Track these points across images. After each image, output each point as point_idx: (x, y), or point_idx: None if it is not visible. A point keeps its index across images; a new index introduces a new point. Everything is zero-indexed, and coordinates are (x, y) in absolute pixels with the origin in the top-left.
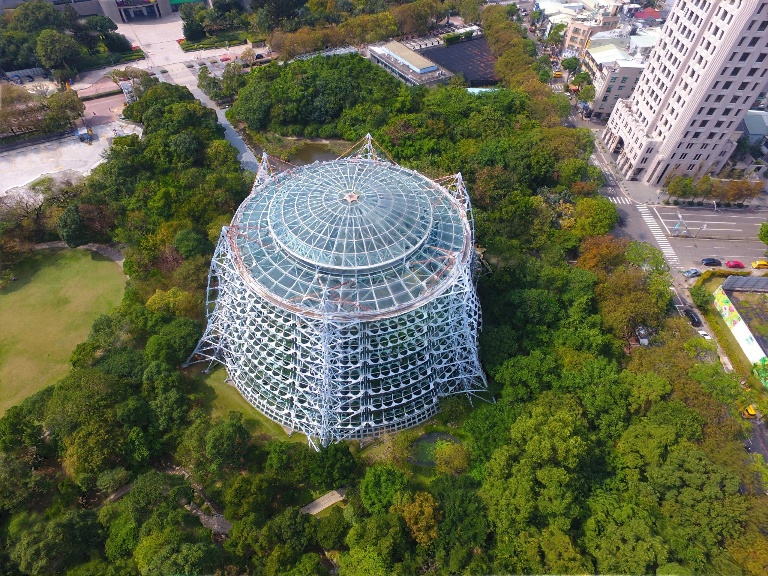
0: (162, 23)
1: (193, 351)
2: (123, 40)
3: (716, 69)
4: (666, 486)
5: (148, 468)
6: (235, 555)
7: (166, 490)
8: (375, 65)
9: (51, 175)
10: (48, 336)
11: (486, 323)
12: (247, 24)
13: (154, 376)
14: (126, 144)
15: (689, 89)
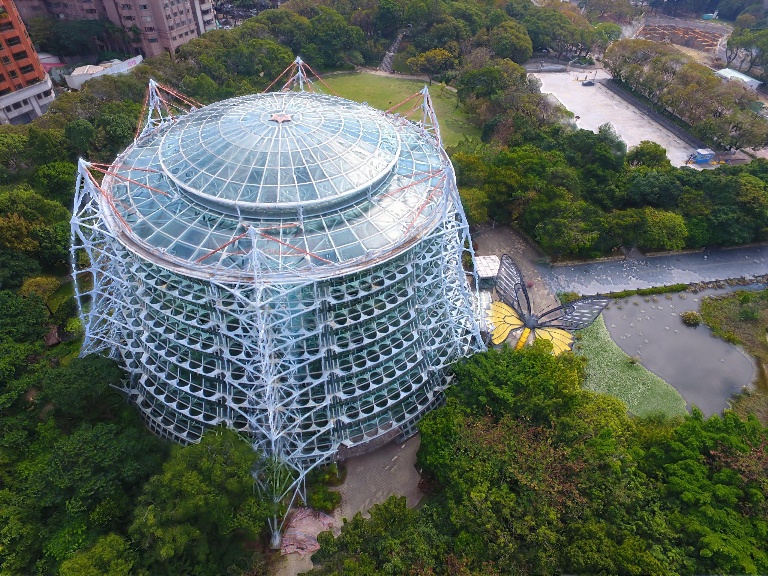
0: None
1: None
2: None
3: None
4: None
5: None
6: None
7: None
8: None
9: (551, 97)
10: None
11: None
12: None
13: None
14: (644, 149)
15: None
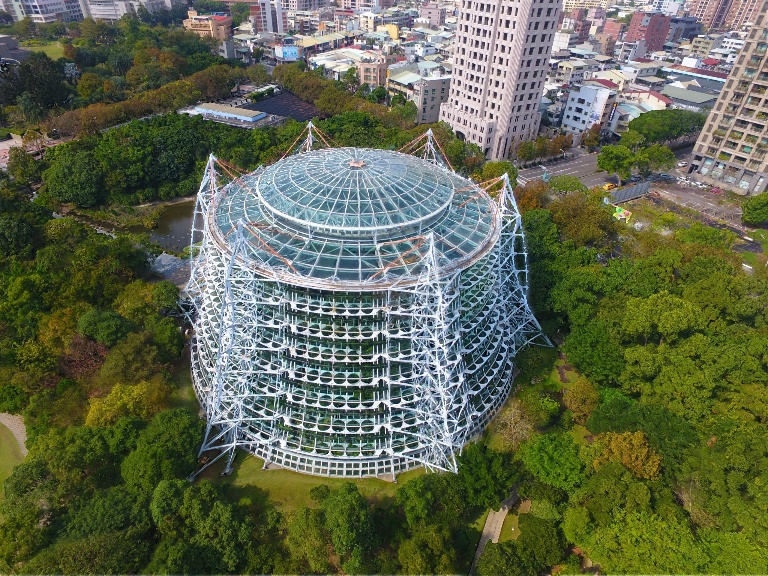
0: None
1: (199, 450)
2: None
3: (519, 51)
4: (753, 315)
5: None
6: None
7: None
8: None
9: None
10: None
11: None
12: (4, 117)
13: (172, 503)
14: None
15: (503, 73)
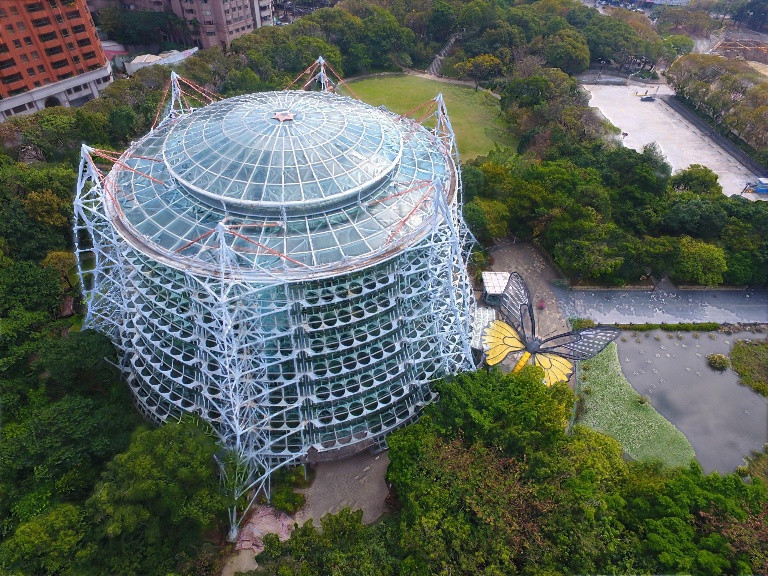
0: None
1: None
2: None
3: None
4: None
5: None
6: None
7: None
8: None
9: (596, 111)
10: None
11: None
12: None
13: None
14: (692, 173)
15: None
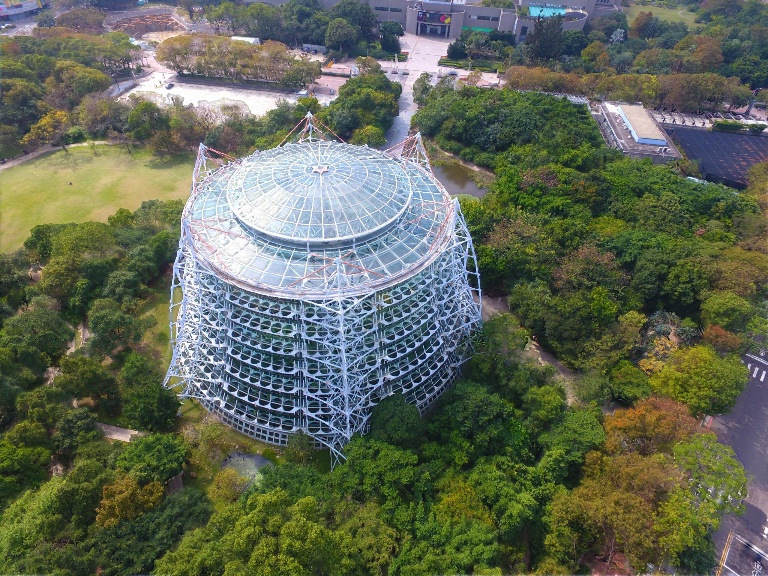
0: (444, 42)
1: (183, 259)
2: (396, 43)
3: None
4: None
5: (79, 317)
6: (16, 406)
7: (41, 328)
8: (592, 119)
9: (228, 100)
10: (140, 204)
11: (436, 405)
12: (507, 56)
13: (136, 256)
14: (305, 104)
15: None
